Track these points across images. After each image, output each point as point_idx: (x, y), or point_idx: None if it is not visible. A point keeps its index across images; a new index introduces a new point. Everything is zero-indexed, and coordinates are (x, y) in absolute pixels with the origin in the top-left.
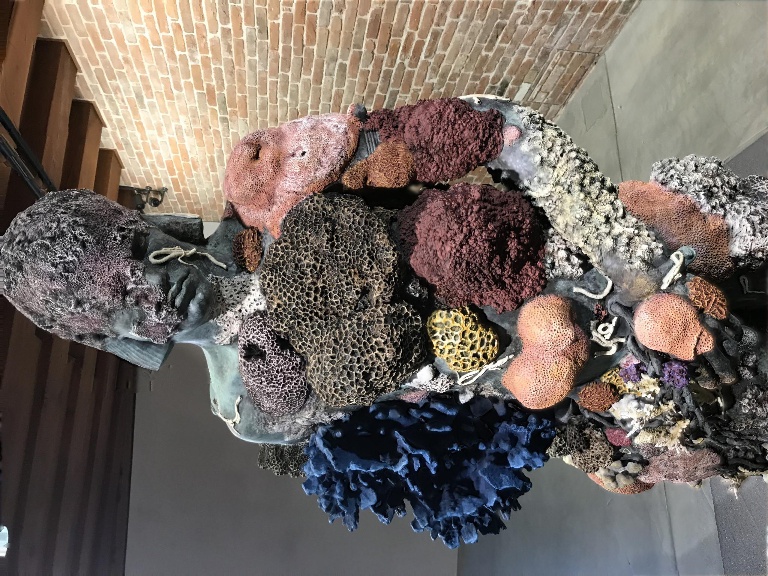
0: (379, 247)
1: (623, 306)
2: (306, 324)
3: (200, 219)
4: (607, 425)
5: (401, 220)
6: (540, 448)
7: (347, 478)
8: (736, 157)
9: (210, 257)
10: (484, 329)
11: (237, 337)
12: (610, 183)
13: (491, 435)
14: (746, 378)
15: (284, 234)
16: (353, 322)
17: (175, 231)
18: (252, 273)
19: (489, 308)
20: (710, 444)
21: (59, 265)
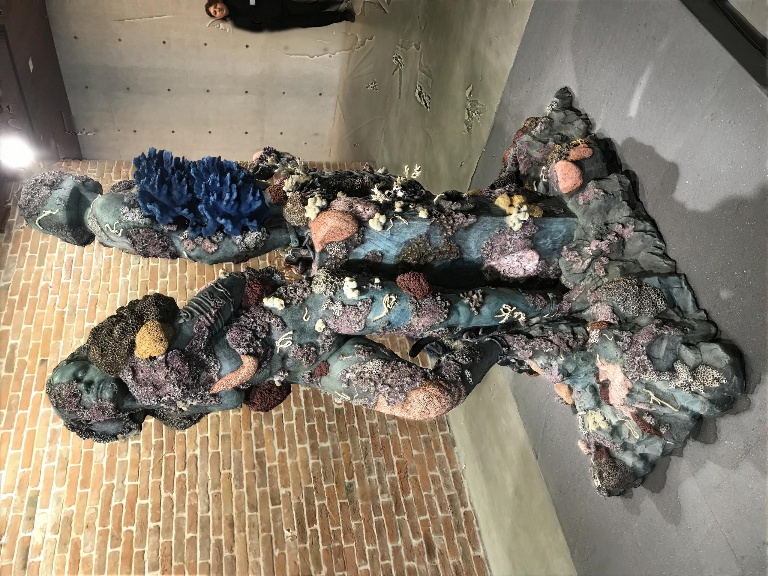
0: None
1: None
2: None
3: None
4: None
5: None
6: None
7: None
8: (569, 546)
9: None
10: None
11: None
12: None
13: None
14: None
15: None
16: None
17: None
18: None
19: None
20: None
21: None
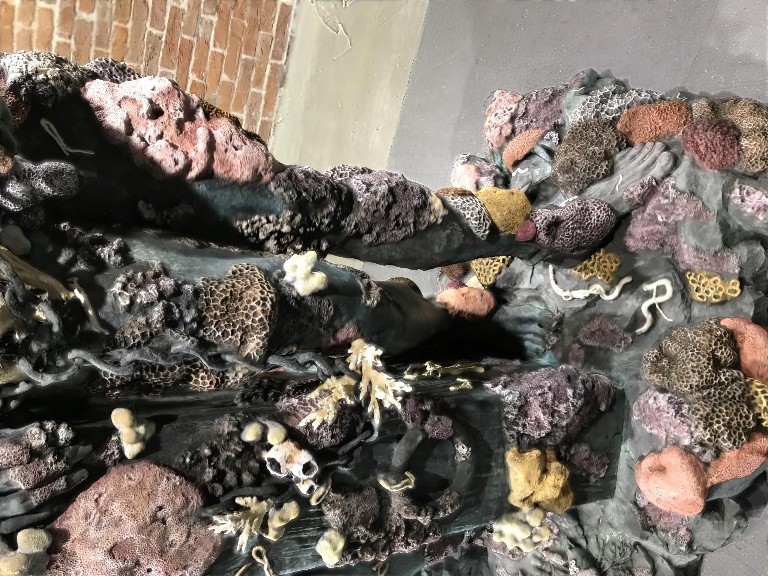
0: None
1: None
2: None
3: None
4: None
5: None
6: None
7: None
8: None
9: None
10: None
11: None
12: None
13: None
14: (114, 264)
15: None
16: None
17: None
18: None
19: None
20: (166, 463)
21: None
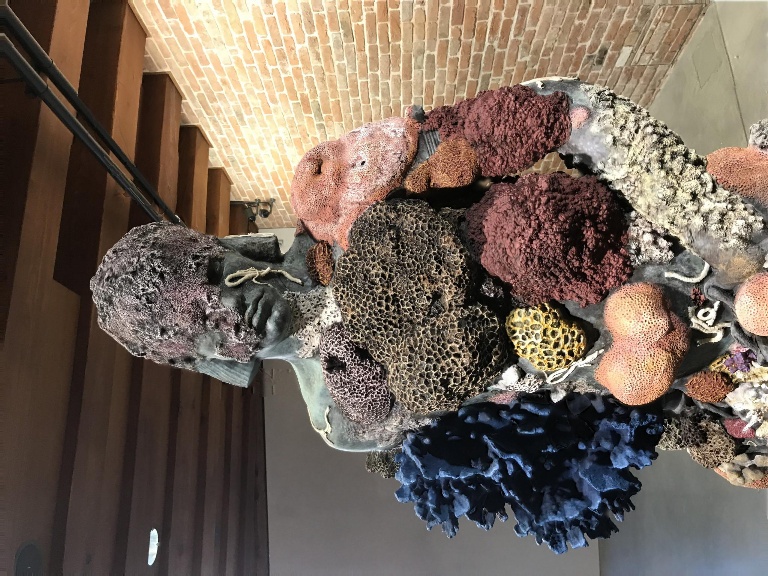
0: (445, 250)
1: (722, 289)
2: (381, 333)
3: (274, 237)
4: (725, 416)
5: (469, 219)
6: (647, 445)
7: (439, 485)
8: None
9: (285, 274)
10: (567, 325)
11: (318, 350)
12: (695, 155)
13: (591, 433)
14: None
15: (351, 246)
16: (427, 328)
17: (252, 251)
18: (326, 286)
19: (571, 302)
20: None
21: (143, 297)
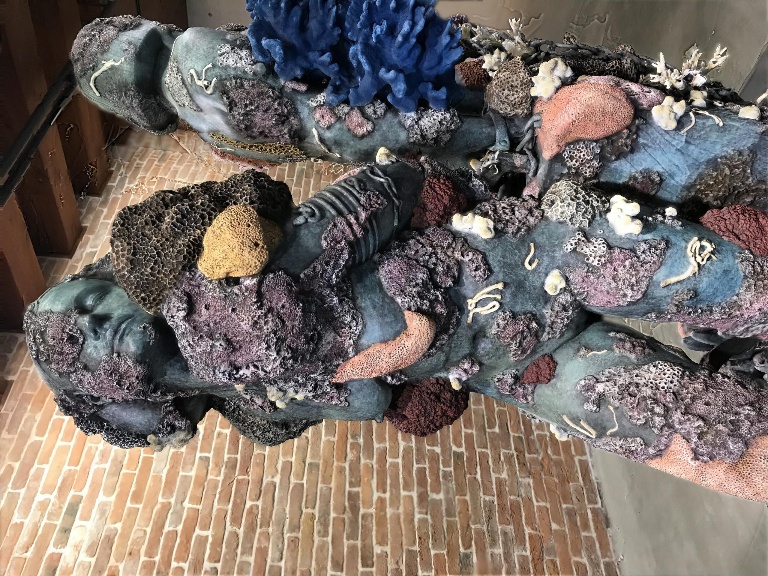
0: None
1: None
2: None
3: None
4: None
5: None
6: None
7: None
8: None
9: None
10: None
11: None
12: None
13: None
14: None
15: None
16: None
17: None
18: None
19: None
20: None
21: None
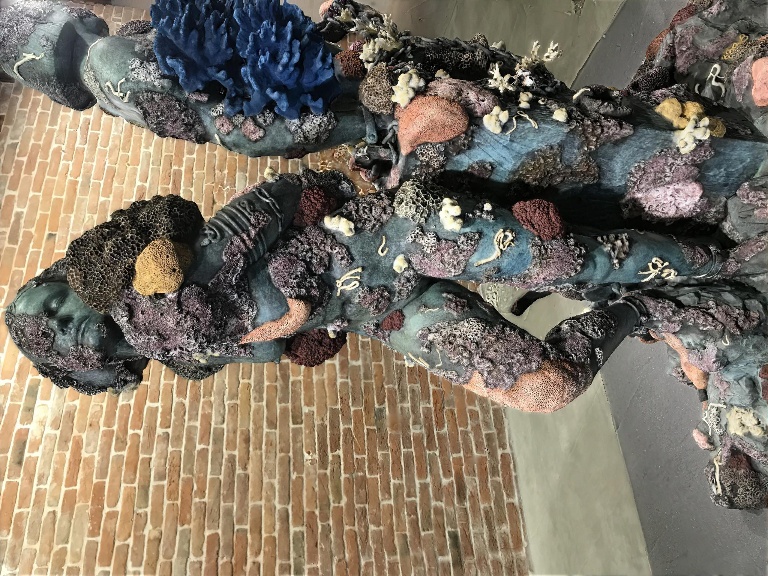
0: None
1: None
2: None
3: None
4: None
5: None
6: None
7: None
8: (645, 538)
9: None
10: None
11: None
12: None
13: None
14: None
15: None
16: None
17: None
18: None
19: None
20: None
21: None
